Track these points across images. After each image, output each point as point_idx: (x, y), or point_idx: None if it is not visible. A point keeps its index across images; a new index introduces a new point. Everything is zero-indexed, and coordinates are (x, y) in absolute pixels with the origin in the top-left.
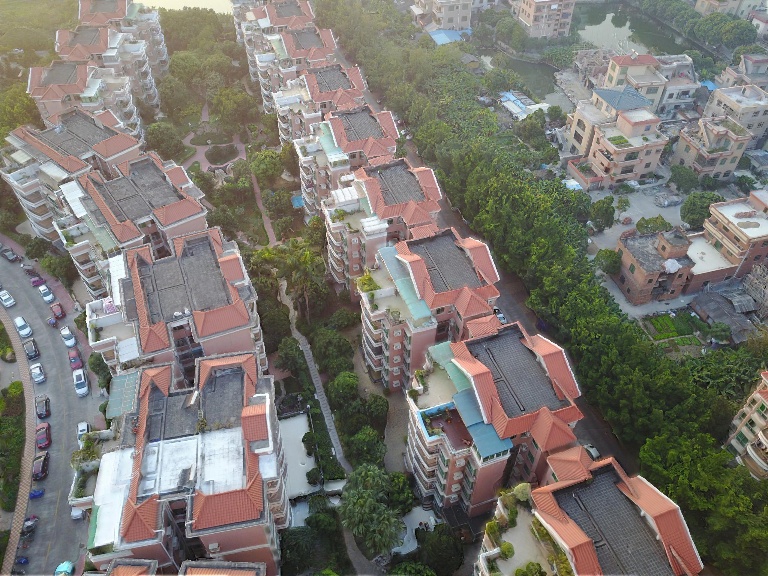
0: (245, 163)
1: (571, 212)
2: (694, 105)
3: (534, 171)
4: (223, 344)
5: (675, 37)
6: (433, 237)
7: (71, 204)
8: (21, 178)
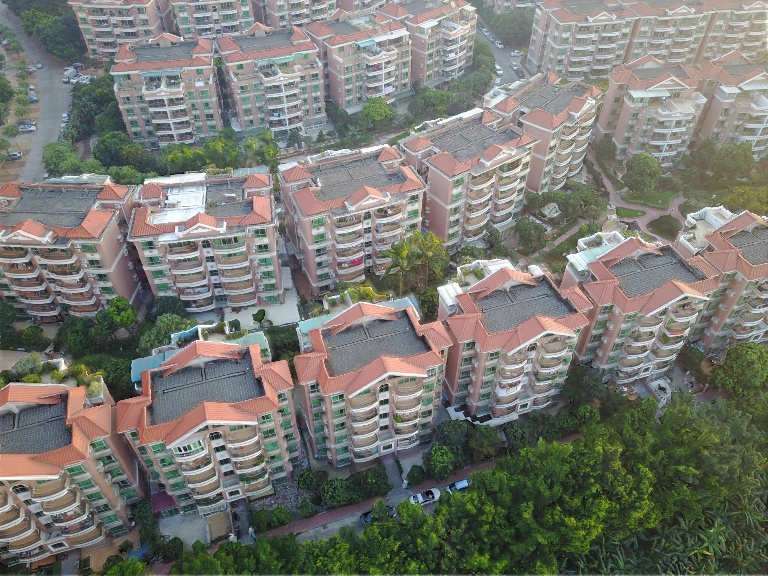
0: None
1: None
2: None
3: None
4: None
5: None
6: None
7: None
8: None
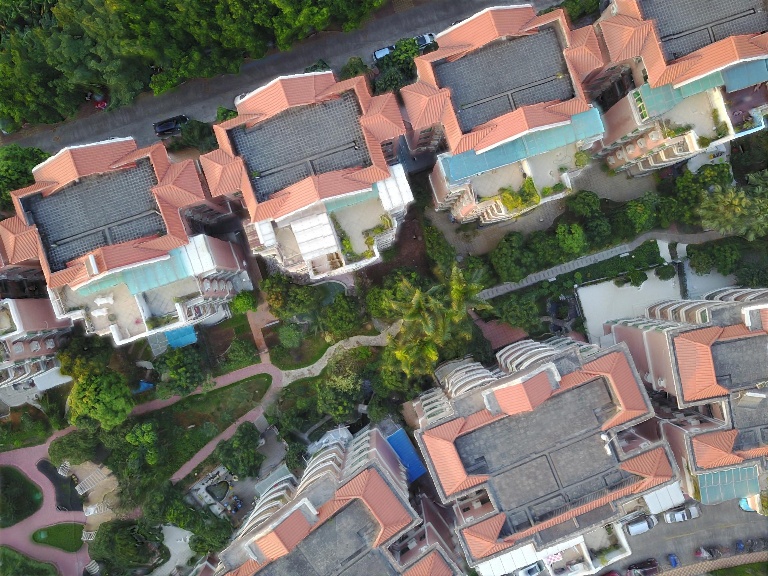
0: (66, 443)
1: None
2: None
3: None
4: None
5: None
6: None
7: None
8: None
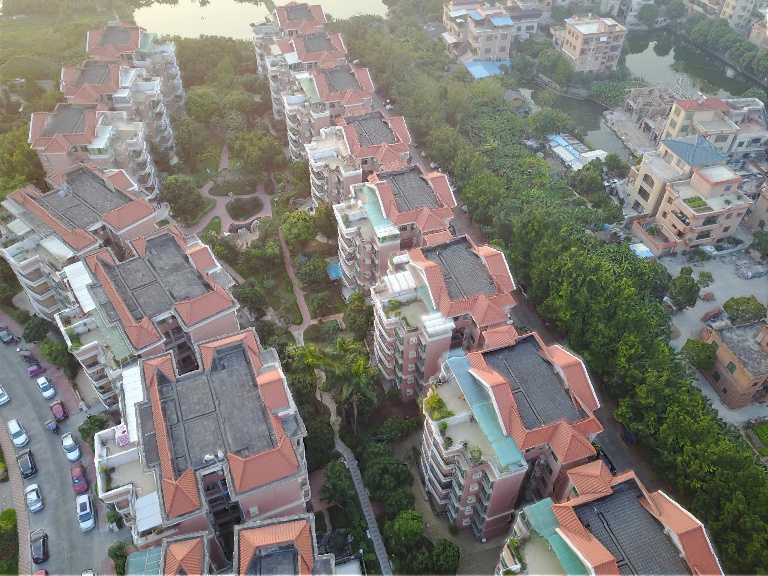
0: (272, 222)
1: (646, 287)
2: (765, 154)
3: (596, 233)
4: (265, 496)
5: (727, 70)
6: (512, 345)
7: (77, 293)
8: (18, 253)
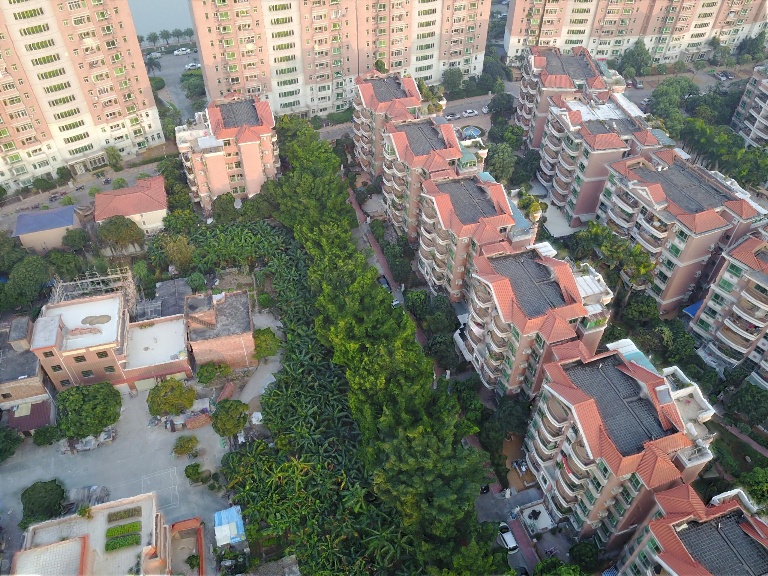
0: None
1: None
2: None
3: (279, 575)
4: None
5: None
6: None
7: None
8: None
